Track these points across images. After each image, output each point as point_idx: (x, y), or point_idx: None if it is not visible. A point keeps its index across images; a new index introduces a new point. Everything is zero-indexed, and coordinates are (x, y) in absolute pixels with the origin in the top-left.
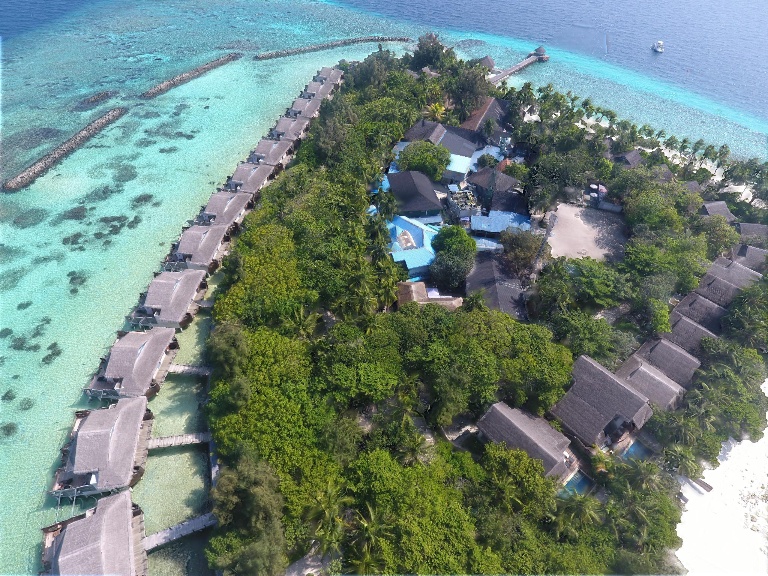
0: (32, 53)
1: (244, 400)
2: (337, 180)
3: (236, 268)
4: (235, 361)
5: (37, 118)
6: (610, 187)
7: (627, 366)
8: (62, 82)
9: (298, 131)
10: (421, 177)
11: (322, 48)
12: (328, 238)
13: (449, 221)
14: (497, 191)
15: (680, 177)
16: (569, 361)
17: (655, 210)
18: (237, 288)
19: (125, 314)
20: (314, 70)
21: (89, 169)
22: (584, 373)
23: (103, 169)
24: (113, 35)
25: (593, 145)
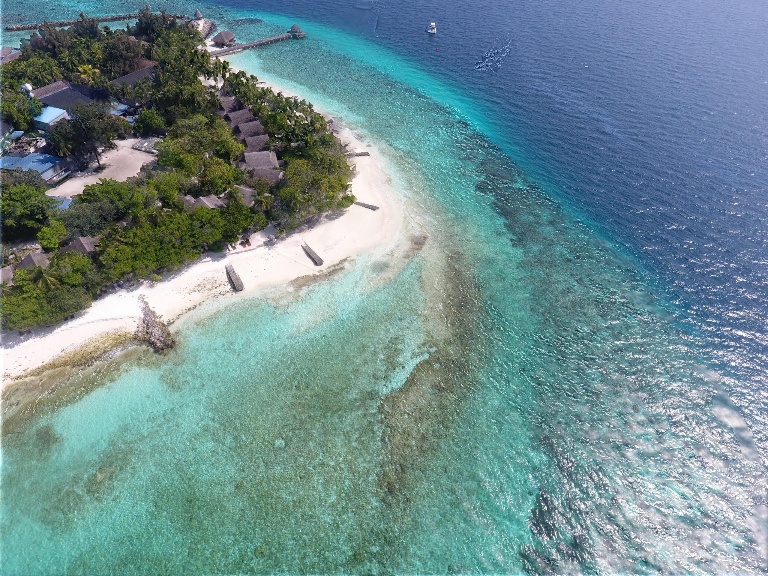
0: None
1: None
2: None
3: None
4: None
5: None
6: None
7: None
8: None
9: None
10: None
11: None
12: None
13: None
14: None
15: None
16: None
17: (171, 154)
18: None
19: None
20: None
21: None
22: None
23: None
24: None
25: (194, 102)
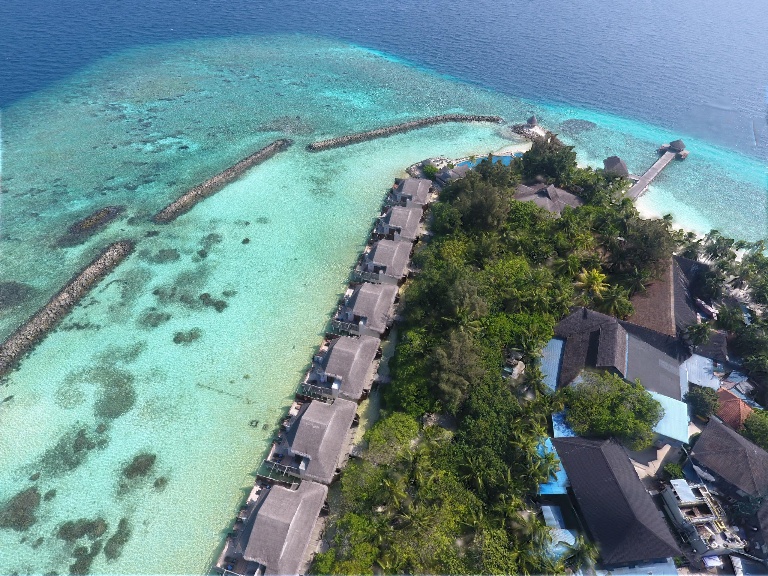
0: (22, 134)
1: None
2: (496, 511)
3: None
4: None
5: (2, 260)
6: None
7: None
8: (51, 187)
9: (386, 312)
10: (619, 457)
11: (393, 132)
12: None
13: (678, 556)
14: (762, 500)
15: None
16: None
17: None
18: None
19: None
20: (387, 170)
21: (60, 383)
22: None
23: (82, 383)
24: (129, 105)
25: None
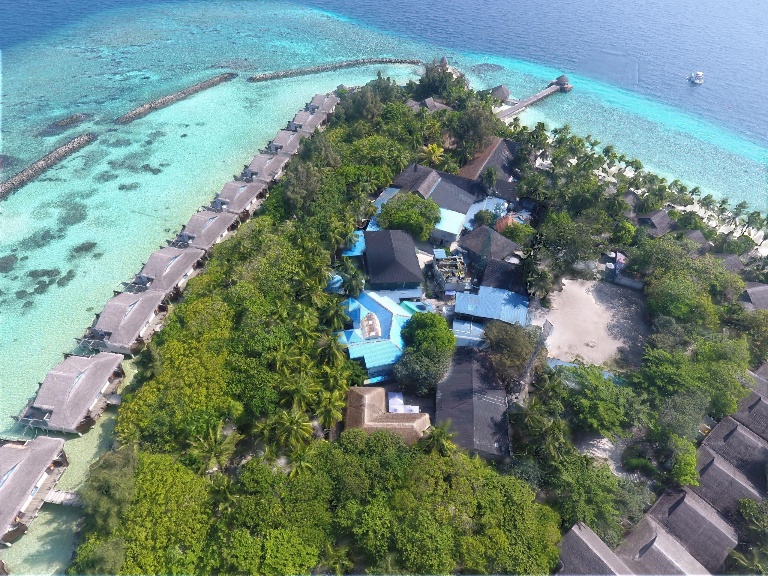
0: (15, 67)
1: (110, 574)
2: (297, 244)
3: (150, 362)
4: (110, 512)
5: None
6: (630, 260)
7: (636, 534)
8: (37, 101)
9: (274, 171)
10: (403, 238)
11: (324, 70)
12: (269, 327)
13: (432, 294)
14: (492, 260)
15: (717, 248)
16: (555, 540)
17: (684, 298)
18: (148, 389)
19: (20, 406)
20: (310, 95)
21: (35, 207)
22: (575, 556)
23: (50, 208)
24: (106, 49)
25: (613, 204)
